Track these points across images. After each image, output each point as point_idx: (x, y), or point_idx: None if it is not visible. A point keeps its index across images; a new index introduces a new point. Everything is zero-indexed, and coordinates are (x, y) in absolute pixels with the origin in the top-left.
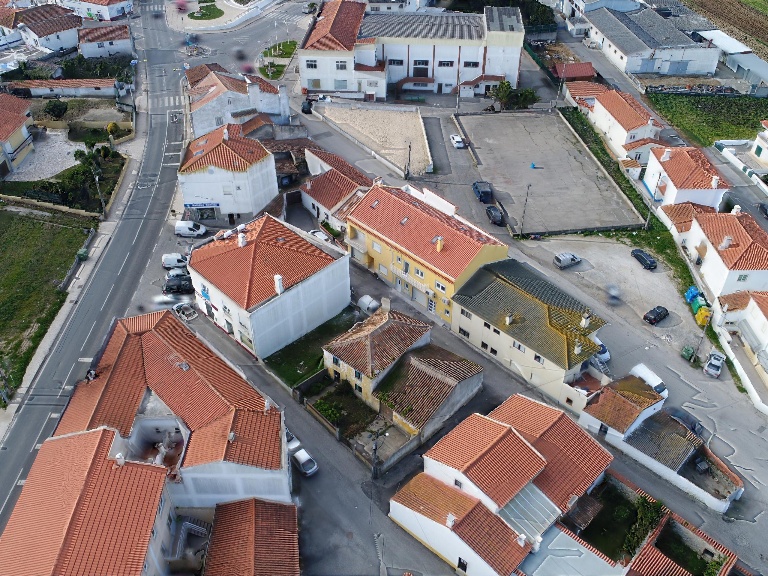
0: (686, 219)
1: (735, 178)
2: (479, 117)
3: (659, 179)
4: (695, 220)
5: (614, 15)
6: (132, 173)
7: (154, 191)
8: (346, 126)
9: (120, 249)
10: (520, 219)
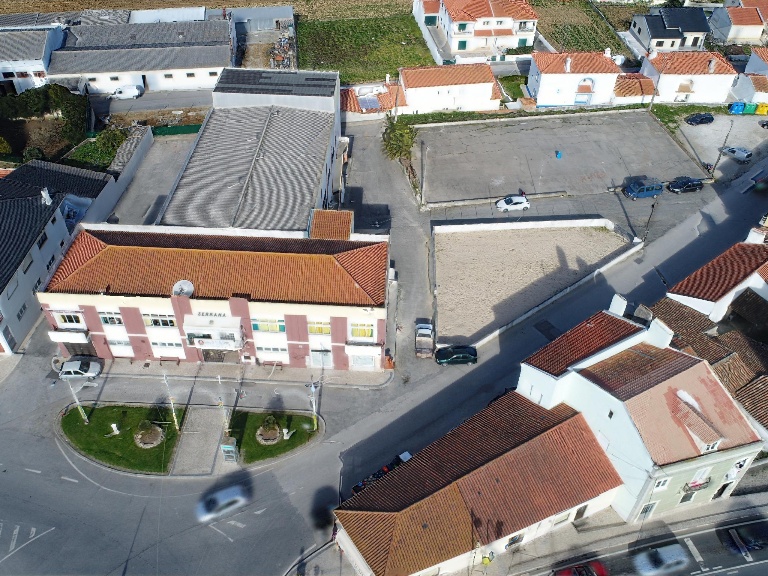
0: (639, 87)
1: (504, 68)
2: (429, 185)
3: (576, 87)
4: (670, 75)
5: (87, 51)
6: None
7: None
8: (505, 308)
9: None
10: (677, 175)
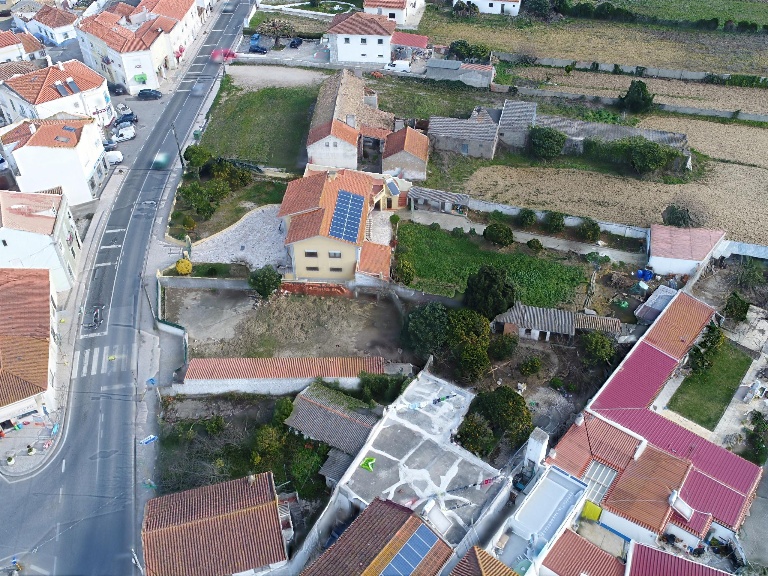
0: None
1: None
2: None
3: None
4: None
5: None
6: (163, 218)
7: (139, 196)
8: None
9: (171, 146)
10: None
